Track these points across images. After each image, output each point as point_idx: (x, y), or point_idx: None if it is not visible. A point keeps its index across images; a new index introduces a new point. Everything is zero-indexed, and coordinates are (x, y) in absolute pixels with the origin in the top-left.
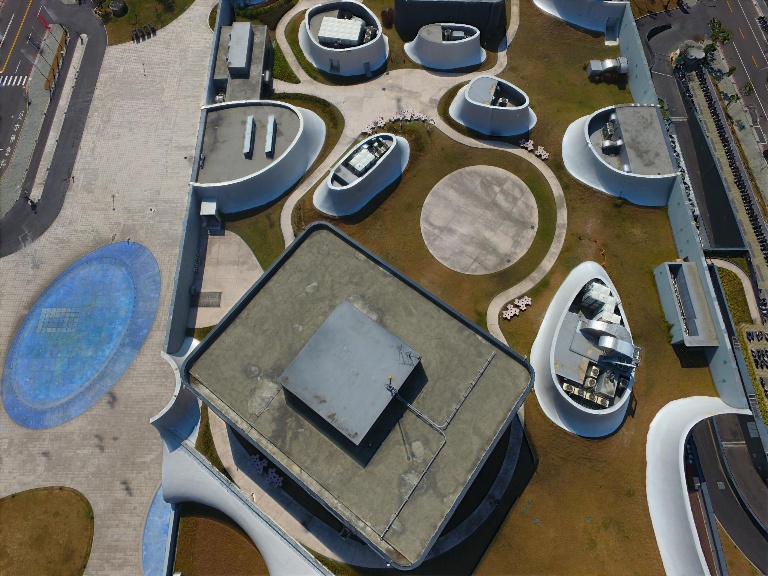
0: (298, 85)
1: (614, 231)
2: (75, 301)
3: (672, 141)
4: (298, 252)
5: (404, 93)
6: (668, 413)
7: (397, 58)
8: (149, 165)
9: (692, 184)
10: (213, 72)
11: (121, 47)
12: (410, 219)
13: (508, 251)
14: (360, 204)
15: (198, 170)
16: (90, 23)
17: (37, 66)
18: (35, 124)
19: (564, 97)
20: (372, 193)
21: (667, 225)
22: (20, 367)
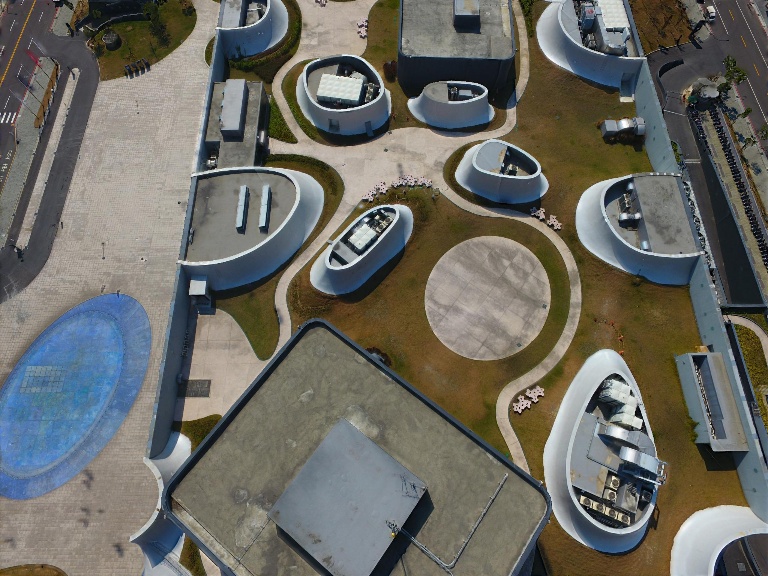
0: (295, 145)
1: (632, 312)
2: (61, 358)
3: (686, 188)
4: (292, 354)
5: (407, 155)
6: (694, 526)
7: (400, 116)
8: (141, 210)
9: (706, 231)
10: (205, 134)
11: (114, 83)
12: (414, 297)
13: (518, 334)
14: (360, 281)
15: (187, 246)
16: (82, 56)
17: (27, 102)
18: (23, 165)
19: (577, 159)
20: (373, 269)
21: (689, 306)
22: (2, 431)
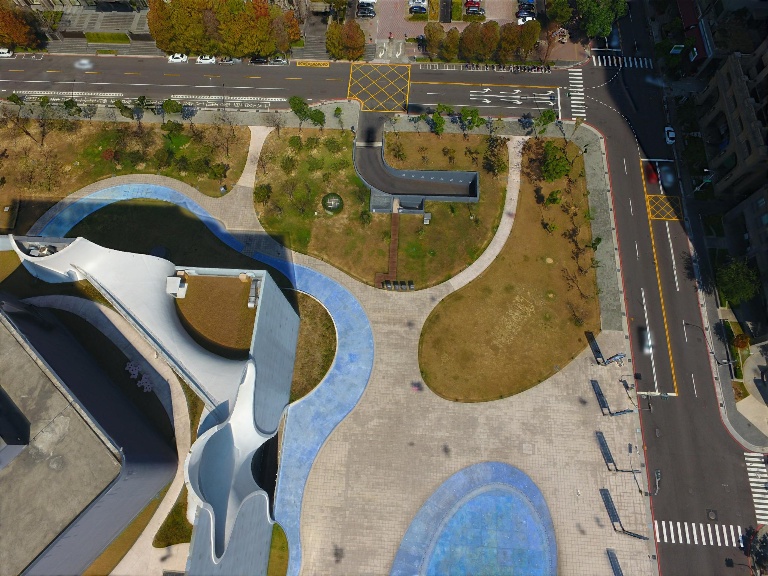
0: None
1: None
2: None
3: None
4: None
5: None
6: None
7: None
8: None
9: None
10: None
11: None
12: None
13: None
14: None
15: None
16: None
17: None
18: None
19: None
20: None
21: None
22: (537, 539)
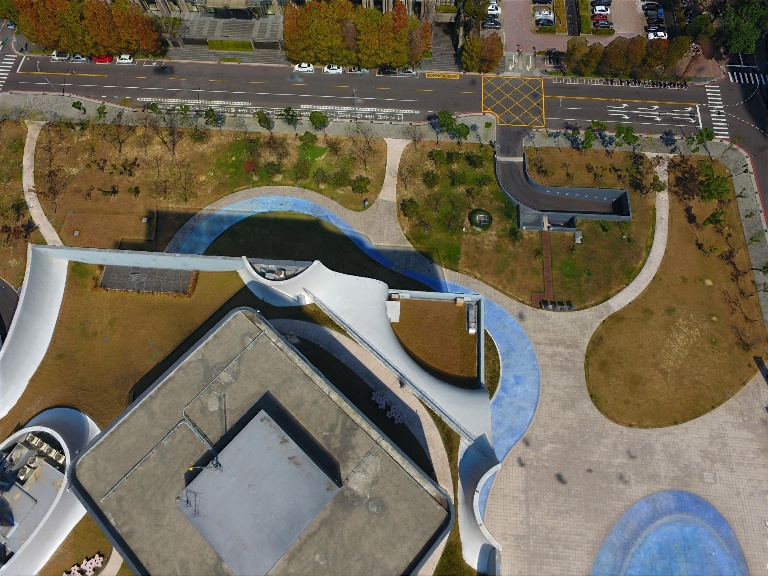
0: None
1: None
2: None
3: None
4: None
5: None
6: None
7: None
8: None
9: None
10: None
11: None
12: None
13: None
14: None
15: None
16: None
17: None
18: None
19: None
20: None
21: None
22: (730, 572)
